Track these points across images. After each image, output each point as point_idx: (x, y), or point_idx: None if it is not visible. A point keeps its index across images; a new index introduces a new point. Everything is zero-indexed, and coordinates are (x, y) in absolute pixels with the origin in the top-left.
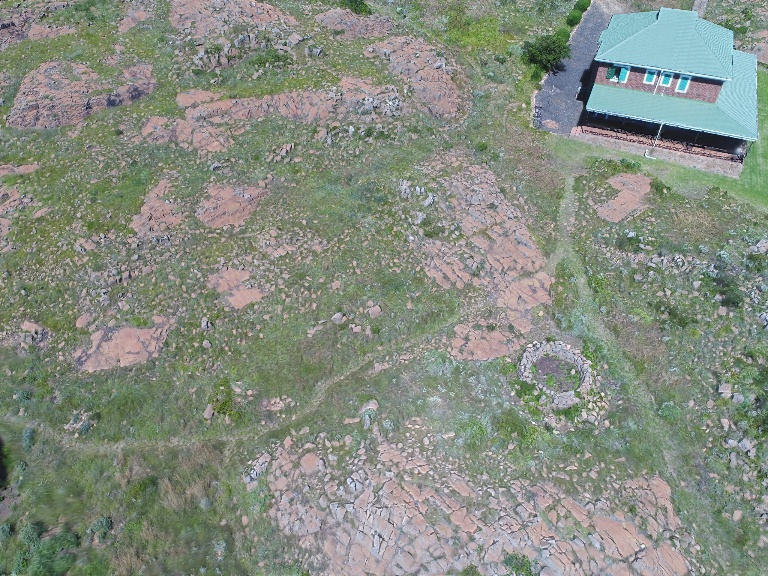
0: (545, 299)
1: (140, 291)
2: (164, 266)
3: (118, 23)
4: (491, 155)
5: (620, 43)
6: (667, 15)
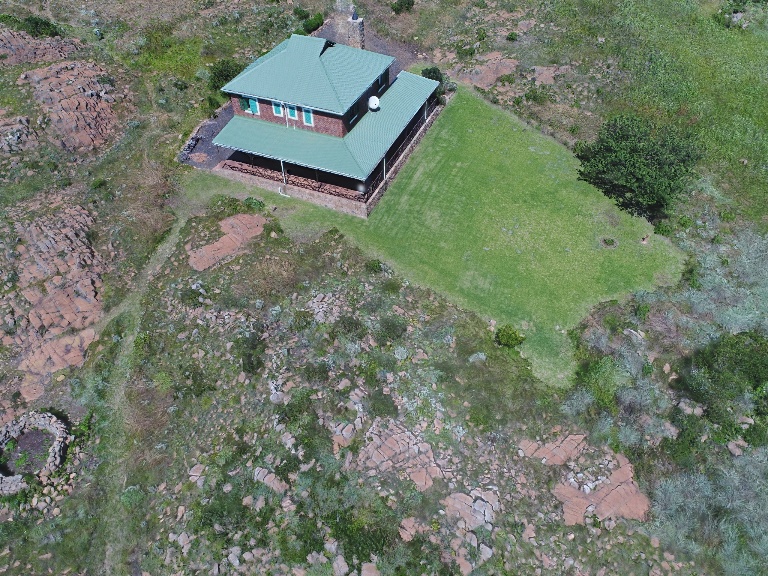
0: (76, 361)
1: None
2: None
3: None
4: (104, 194)
5: (247, 72)
6: (296, 42)
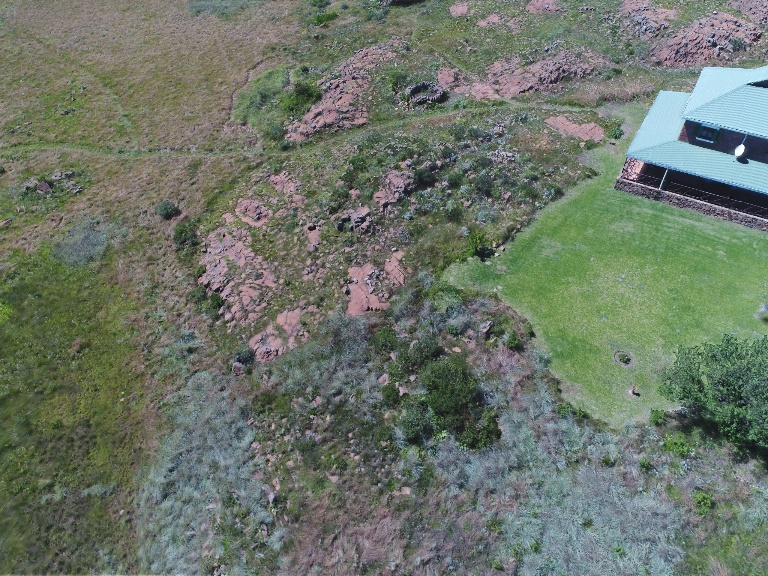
0: (478, 97)
1: (487, 3)
2: (500, 2)
3: None
4: None
5: None
6: (762, 69)
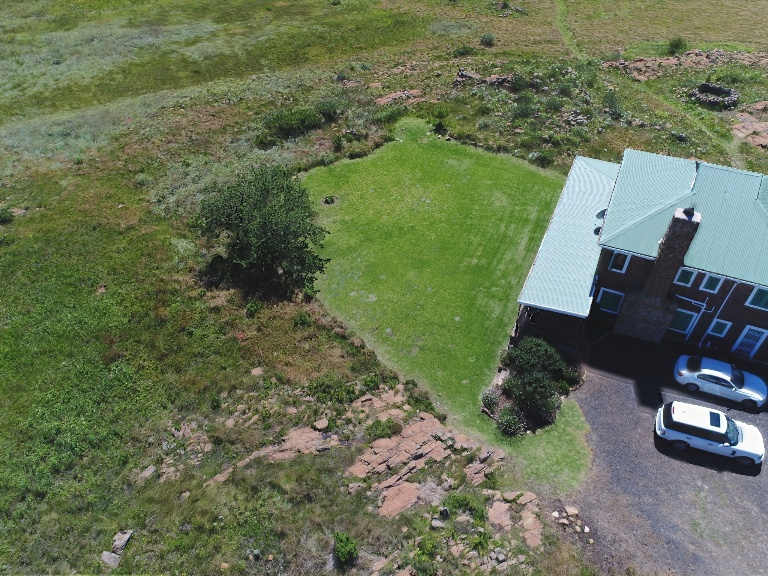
0: None
1: None
2: None
3: None
4: None
5: None
6: None
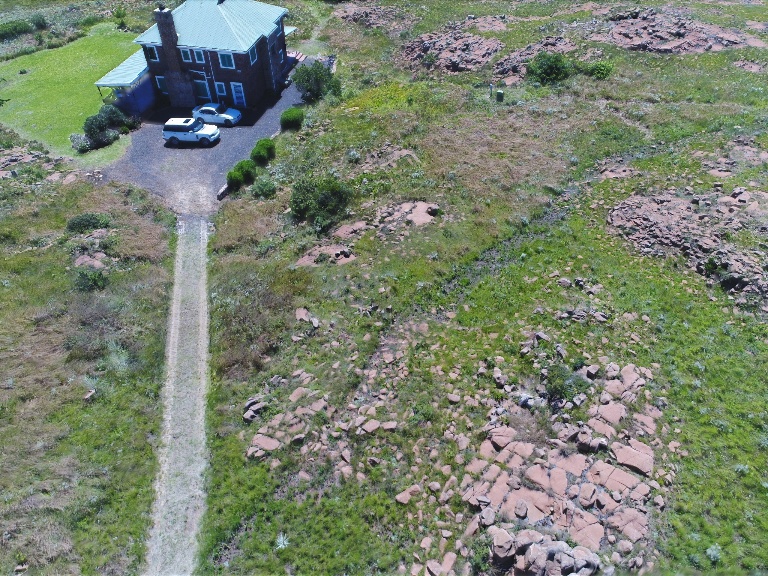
0: None
1: None
2: None
3: (764, 21)
4: None
5: None
6: None
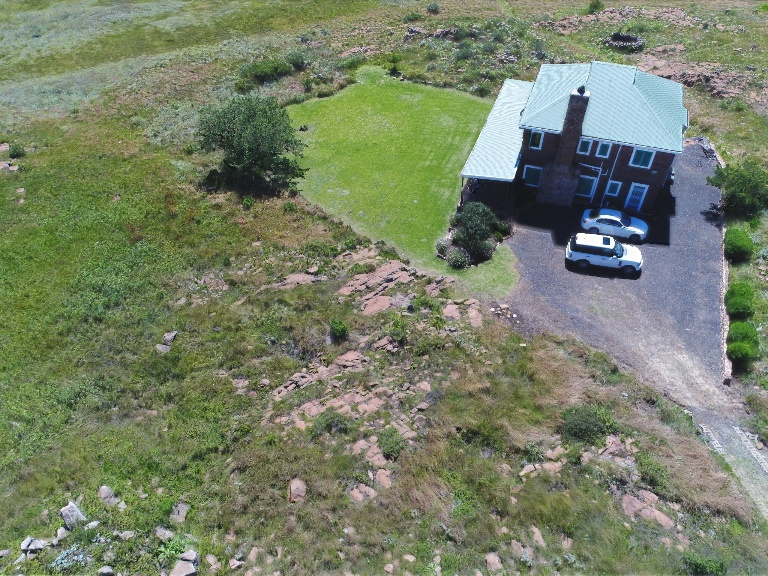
0: None
1: None
2: None
3: None
4: None
5: None
6: None
